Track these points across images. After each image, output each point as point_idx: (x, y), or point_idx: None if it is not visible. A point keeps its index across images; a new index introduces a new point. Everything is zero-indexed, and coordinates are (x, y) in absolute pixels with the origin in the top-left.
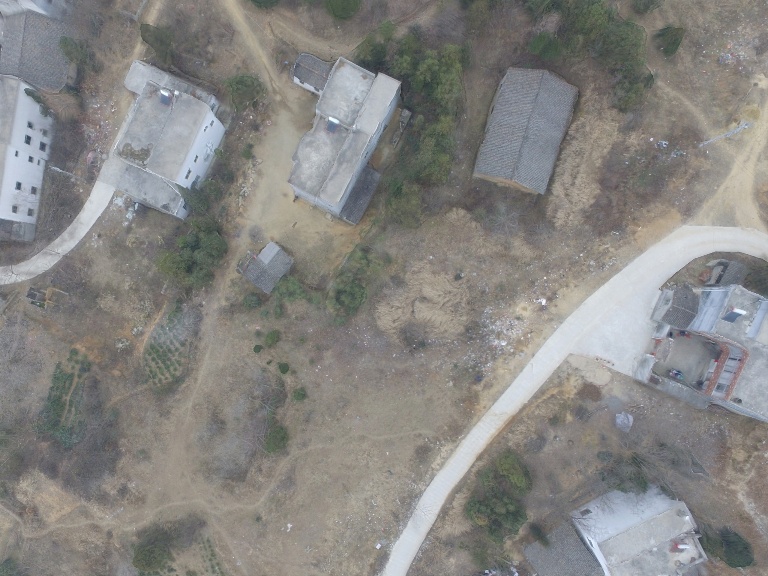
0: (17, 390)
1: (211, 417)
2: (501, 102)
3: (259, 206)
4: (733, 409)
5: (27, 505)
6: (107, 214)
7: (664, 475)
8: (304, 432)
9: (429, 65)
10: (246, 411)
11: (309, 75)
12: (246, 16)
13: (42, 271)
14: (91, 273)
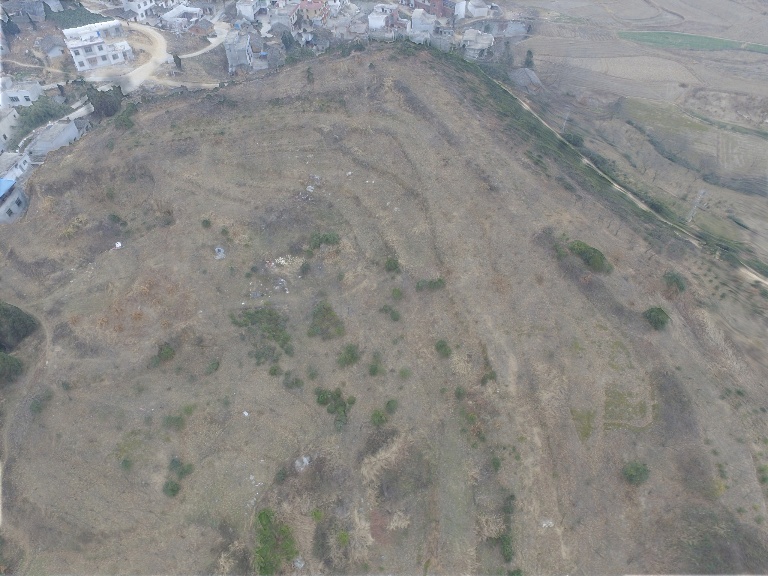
0: None
1: None
2: None
3: None
4: (34, 16)
5: None
6: None
7: None
8: None
9: None
10: None
11: None
12: None
13: None
14: None
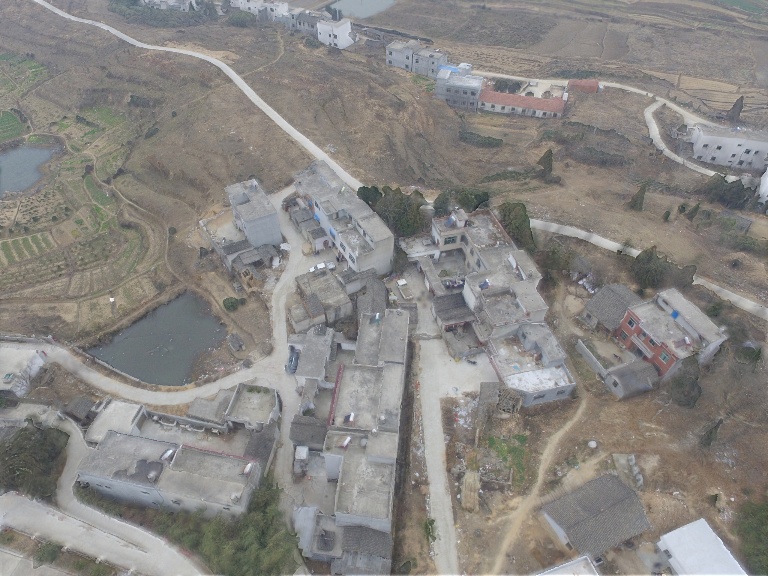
0: None
1: (625, 194)
2: None
3: (767, 224)
4: None
5: None
6: None
7: (725, 357)
8: (642, 218)
9: None
10: None
11: None
12: None
13: (670, 157)
14: (678, 172)
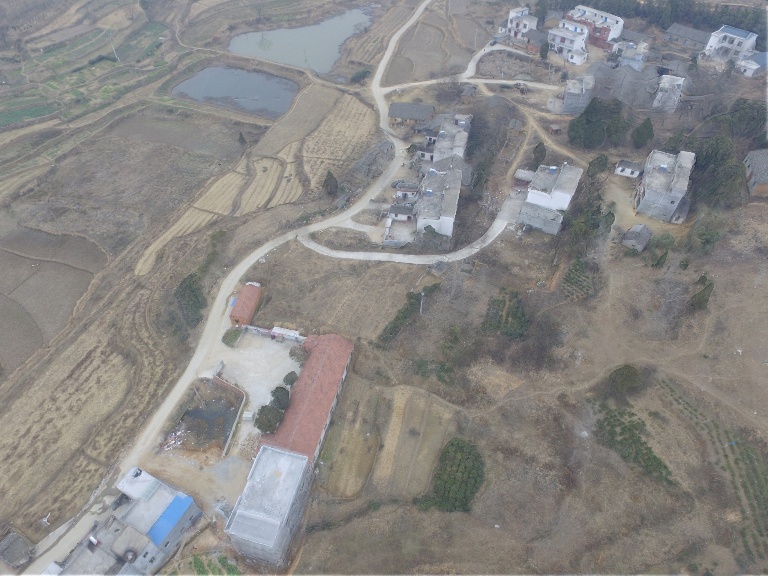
0: (460, 312)
1: (630, 309)
2: (753, 161)
3: None
4: None
5: (475, 387)
6: (504, 233)
7: None
8: (715, 302)
9: (709, 145)
10: (656, 304)
11: (630, 164)
12: (575, 156)
13: (466, 256)
14: (500, 257)
